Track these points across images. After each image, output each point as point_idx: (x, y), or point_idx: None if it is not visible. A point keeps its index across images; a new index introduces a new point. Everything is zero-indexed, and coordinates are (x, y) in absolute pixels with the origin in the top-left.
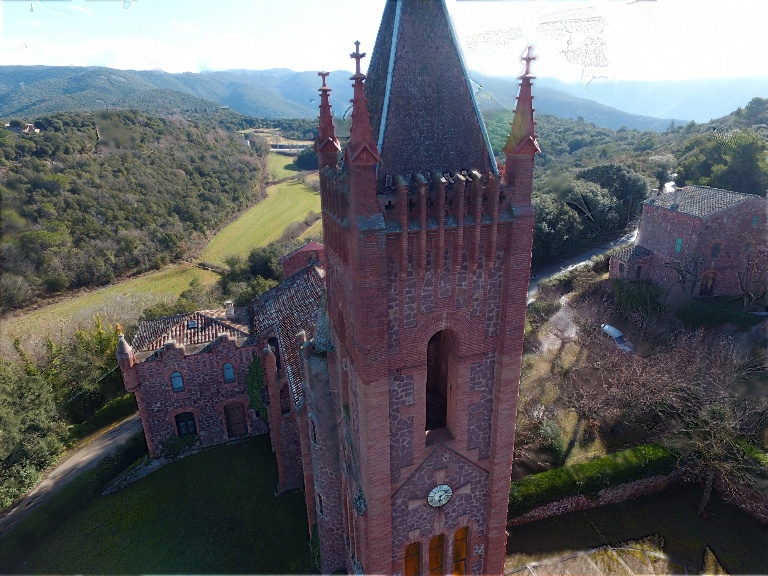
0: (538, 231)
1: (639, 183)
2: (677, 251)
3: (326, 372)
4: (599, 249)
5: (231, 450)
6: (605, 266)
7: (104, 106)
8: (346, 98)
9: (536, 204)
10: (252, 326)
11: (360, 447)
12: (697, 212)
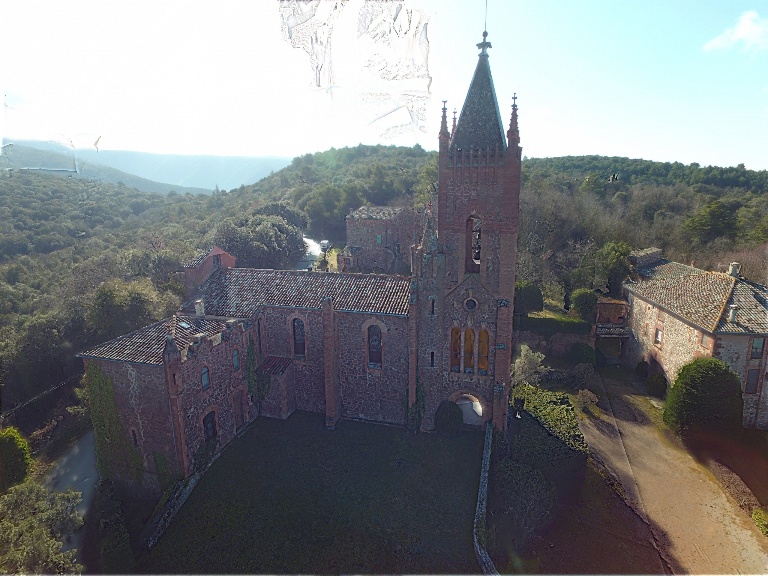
0: None
1: (300, 215)
2: (379, 243)
3: (444, 262)
4: (301, 262)
5: (249, 437)
6: None
7: (3, 89)
8: (54, 127)
9: (261, 230)
10: None
11: (500, 274)
12: (386, 217)
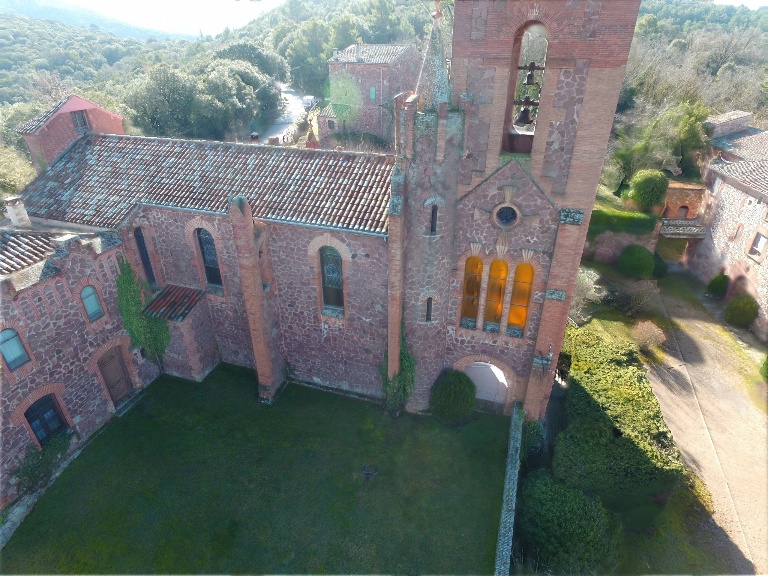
0: (232, 107)
1: (276, 61)
2: (373, 99)
3: (461, 131)
4: (276, 125)
5: (135, 417)
6: (299, 135)
7: None
8: None
9: (216, 79)
10: (73, 230)
11: (574, 158)
12: (382, 61)
